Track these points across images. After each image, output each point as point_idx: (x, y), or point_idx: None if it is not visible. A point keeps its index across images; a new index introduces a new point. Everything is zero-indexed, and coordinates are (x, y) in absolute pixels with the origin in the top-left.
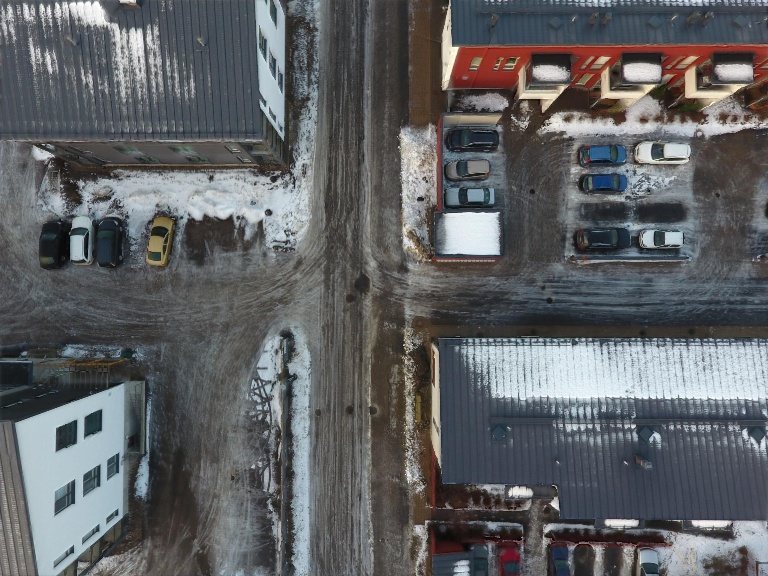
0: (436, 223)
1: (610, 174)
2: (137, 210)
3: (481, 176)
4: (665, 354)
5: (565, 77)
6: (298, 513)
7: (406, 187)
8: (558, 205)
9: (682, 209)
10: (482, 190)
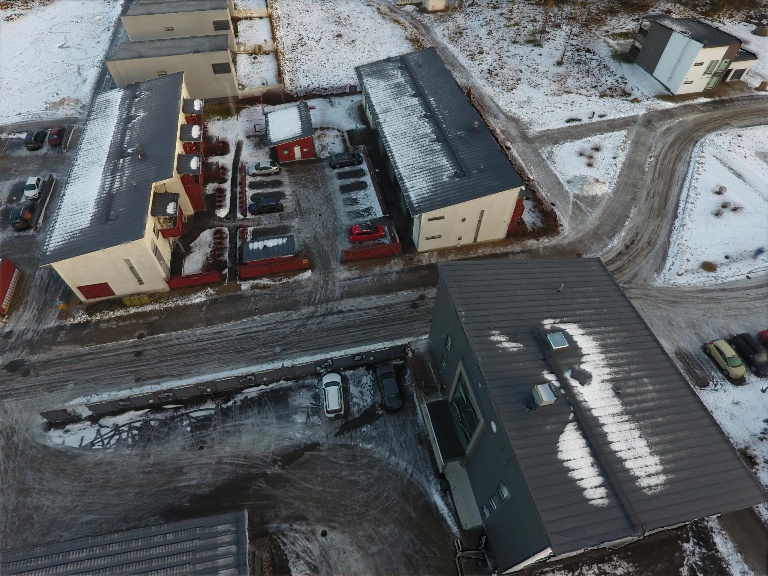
0: None
1: None
2: None
3: None
4: (82, 157)
5: None
6: None
7: None
8: None
9: (18, 184)
10: None
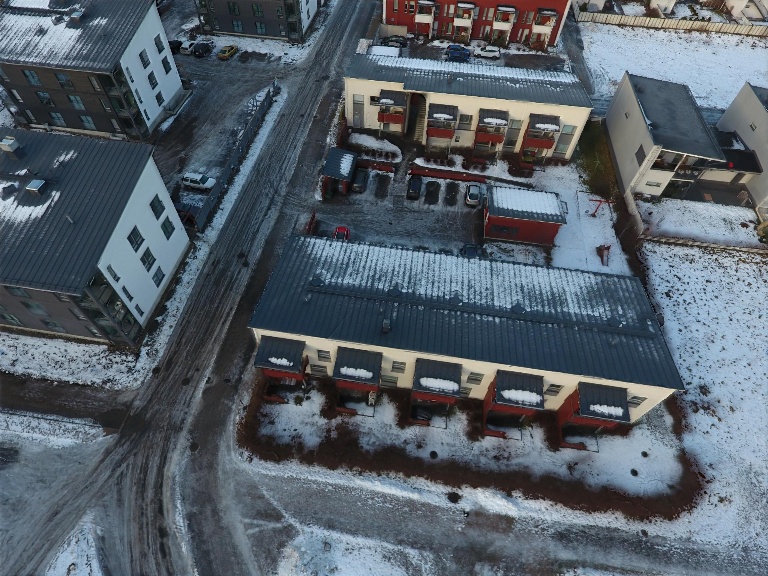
0: (368, 48)
1: None
2: (221, 45)
3: None
4: None
5: (432, 3)
6: (253, 148)
7: (358, 52)
8: None
9: None
10: None
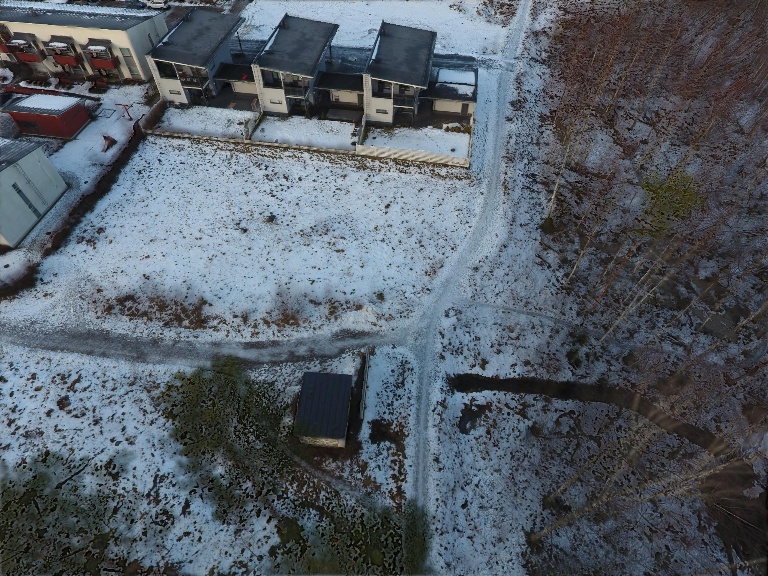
0: None
1: None
2: None
3: (80, 2)
4: None
5: None
6: None
7: None
8: None
9: None
10: (75, 3)
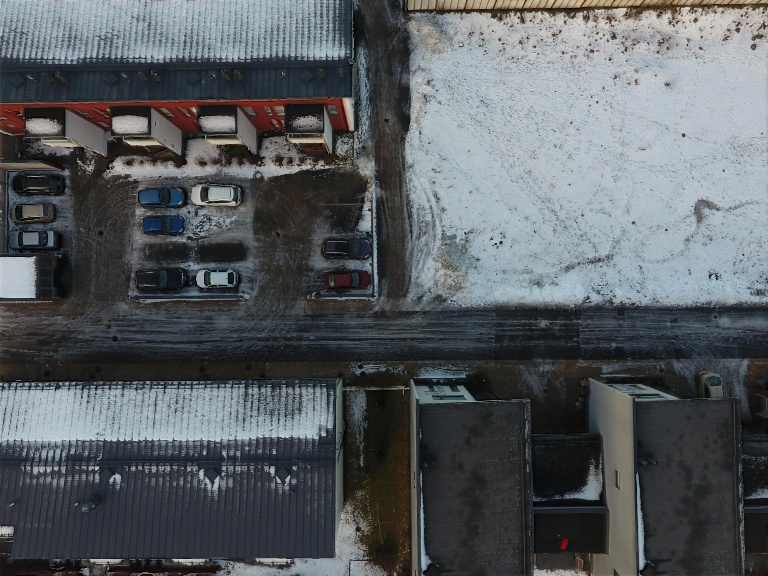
0: None
1: (164, 216)
2: None
3: (40, 219)
4: (141, 397)
5: (56, 129)
6: None
7: None
8: (124, 246)
9: (242, 248)
10: (37, 233)
